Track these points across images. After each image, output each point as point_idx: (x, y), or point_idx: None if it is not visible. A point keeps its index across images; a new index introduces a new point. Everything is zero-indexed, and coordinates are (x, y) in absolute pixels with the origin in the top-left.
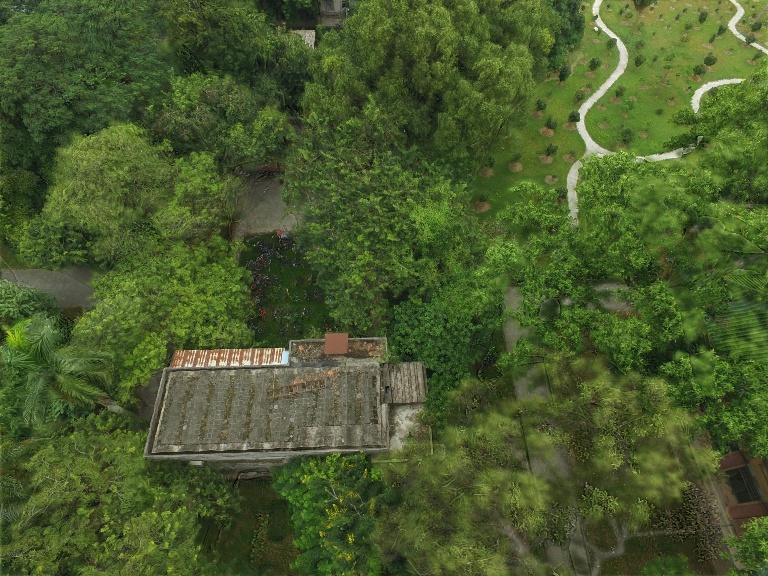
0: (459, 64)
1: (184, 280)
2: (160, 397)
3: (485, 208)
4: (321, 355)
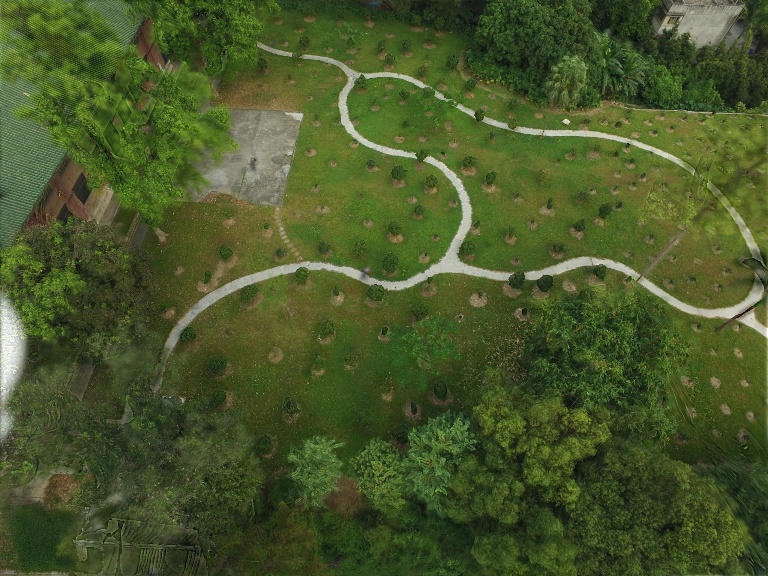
0: None
1: None
2: None
3: (307, 20)
4: None
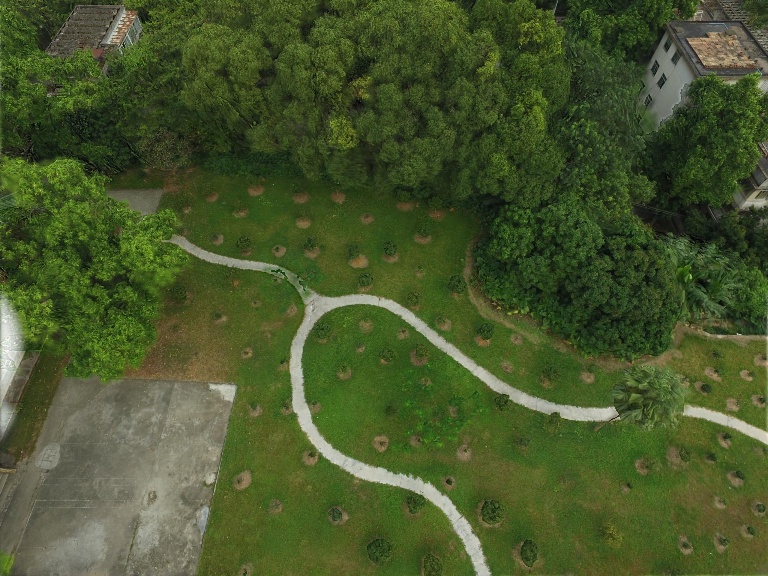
0: (232, 20)
1: (189, 11)
2: (108, 7)
3: (252, 192)
4: (101, 57)
